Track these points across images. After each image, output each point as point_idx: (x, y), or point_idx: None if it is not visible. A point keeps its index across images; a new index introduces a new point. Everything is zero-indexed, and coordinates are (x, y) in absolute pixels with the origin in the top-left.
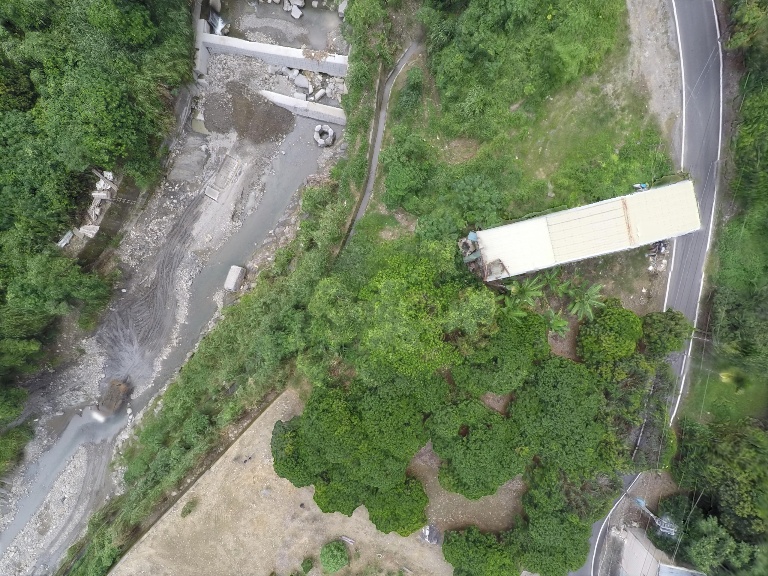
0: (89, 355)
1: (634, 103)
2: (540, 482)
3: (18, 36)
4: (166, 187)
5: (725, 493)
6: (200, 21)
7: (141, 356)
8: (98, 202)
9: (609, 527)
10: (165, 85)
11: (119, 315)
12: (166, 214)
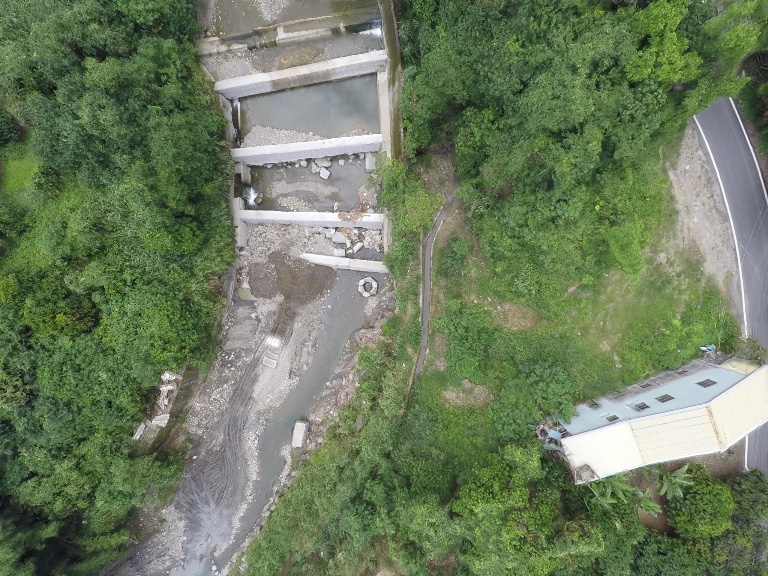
0: (170, 522)
1: (689, 269)
2: None
3: (75, 262)
4: (223, 357)
5: None
6: (235, 200)
7: (219, 515)
8: (166, 393)
9: None
10: (215, 277)
11: (193, 480)
12: (226, 382)
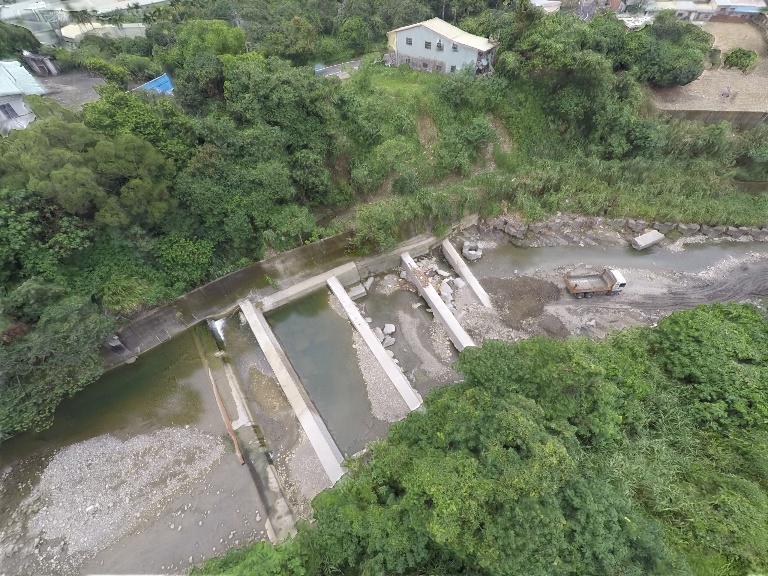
0: None
1: None
2: None
3: None
4: None
5: None
6: None
7: None
8: None
9: None
10: None
11: None
12: None
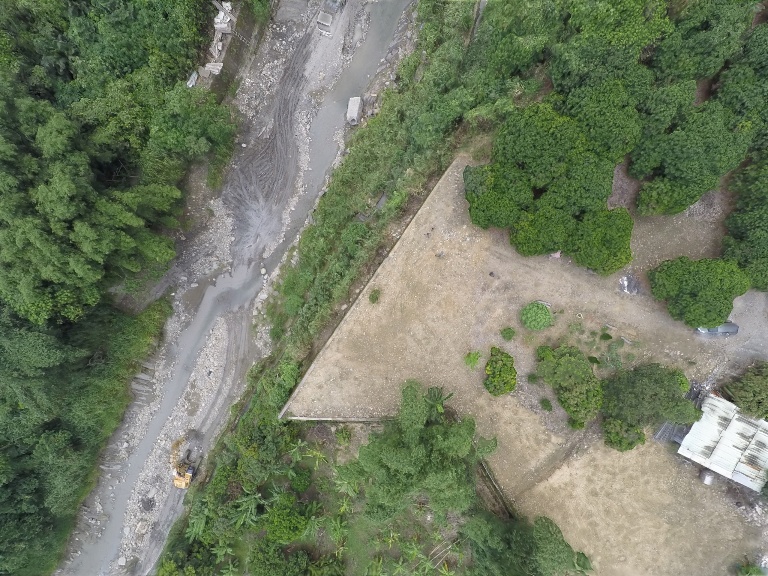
0: (217, 218)
1: None
2: (758, 174)
3: None
4: (274, 29)
5: None
6: None
7: (268, 212)
8: (220, 36)
9: None
10: None
11: (241, 172)
12: (277, 58)
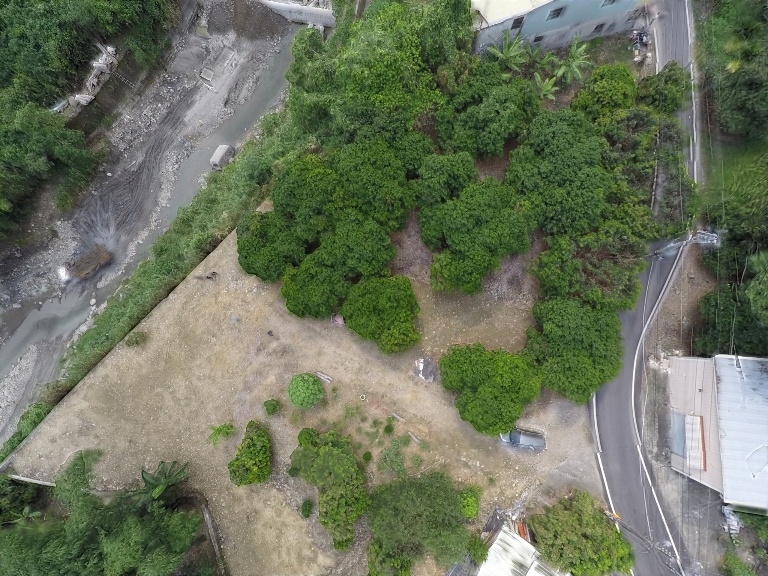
0: (61, 240)
1: None
2: (548, 260)
3: None
4: (165, 79)
5: (767, 206)
6: None
7: (116, 241)
8: (98, 74)
9: (645, 354)
10: None
11: (100, 199)
12: (162, 102)
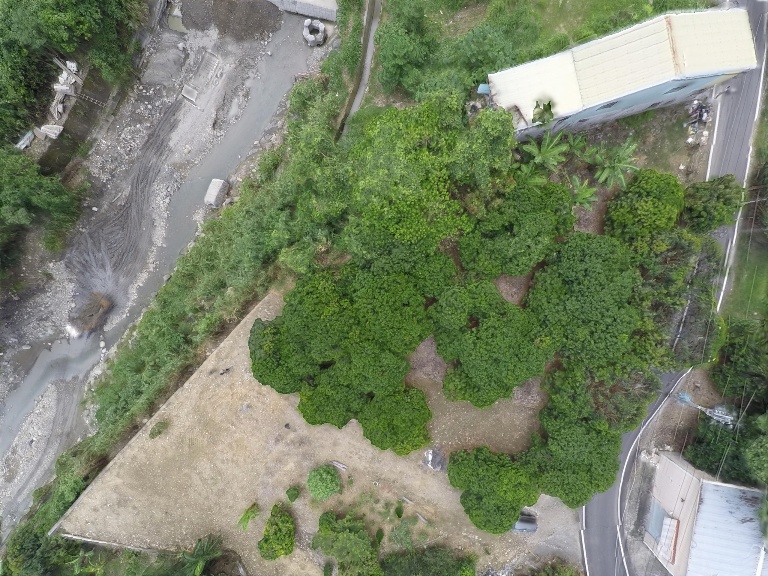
0: (57, 281)
1: None
2: (562, 385)
3: None
4: (140, 91)
5: None
6: None
7: (115, 283)
8: (61, 98)
9: (638, 450)
10: None
11: (90, 237)
12: (140, 122)
